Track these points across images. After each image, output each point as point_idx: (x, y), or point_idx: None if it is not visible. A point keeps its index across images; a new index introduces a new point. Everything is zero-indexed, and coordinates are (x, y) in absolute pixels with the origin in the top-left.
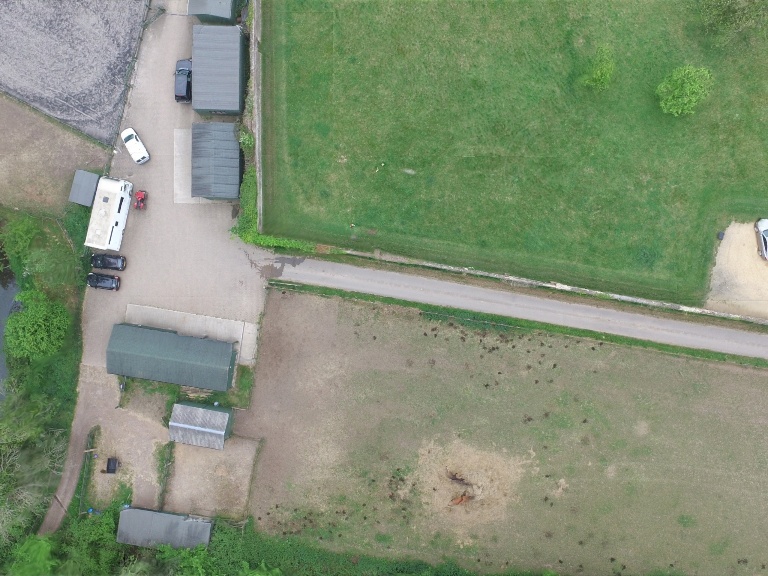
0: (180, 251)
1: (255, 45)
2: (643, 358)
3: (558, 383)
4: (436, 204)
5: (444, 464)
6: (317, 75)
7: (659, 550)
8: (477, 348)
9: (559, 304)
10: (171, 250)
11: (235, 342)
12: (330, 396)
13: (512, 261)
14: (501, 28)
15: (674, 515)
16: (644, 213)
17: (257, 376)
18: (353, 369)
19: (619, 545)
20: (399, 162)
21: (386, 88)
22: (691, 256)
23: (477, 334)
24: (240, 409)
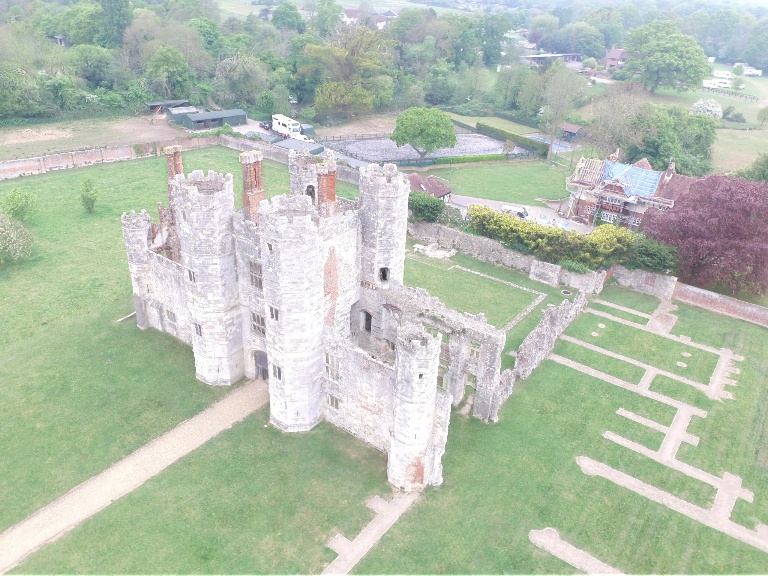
0: None
1: None
2: None
3: None
4: None
5: (55, 135)
6: None
7: None
8: None
9: None
10: None
11: None
12: None
13: (79, 171)
14: None
15: None
16: None
17: None
18: None
19: None
20: None
21: None
22: None
23: None
24: None
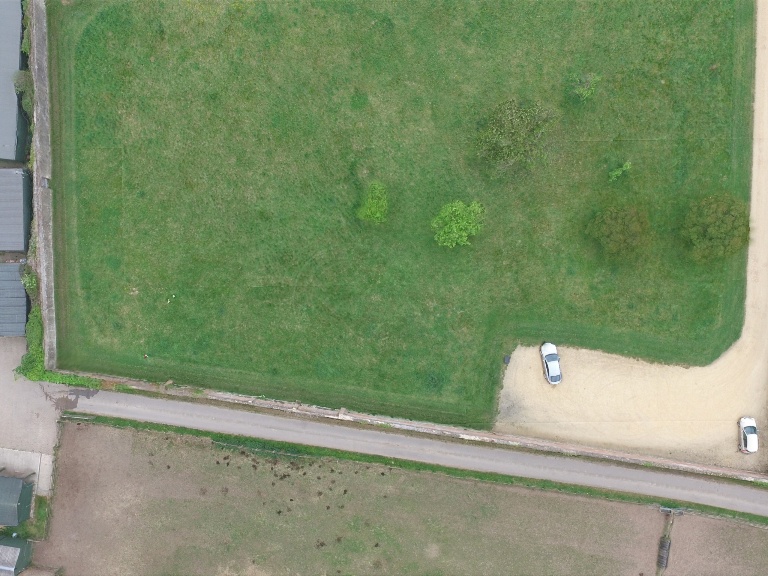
0: None
1: (39, 186)
2: (432, 482)
3: (349, 508)
4: (227, 334)
5: None
6: (107, 210)
7: None
8: (269, 476)
9: (349, 430)
10: None
11: (31, 474)
12: (127, 525)
13: (303, 388)
14: (286, 160)
15: None
16: (431, 339)
17: (55, 506)
18: (148, 498)
19: None
20: (189, 293)
21: (175, 221)
22: (479, 380)
23: (268, 462)
24: (35, 541)
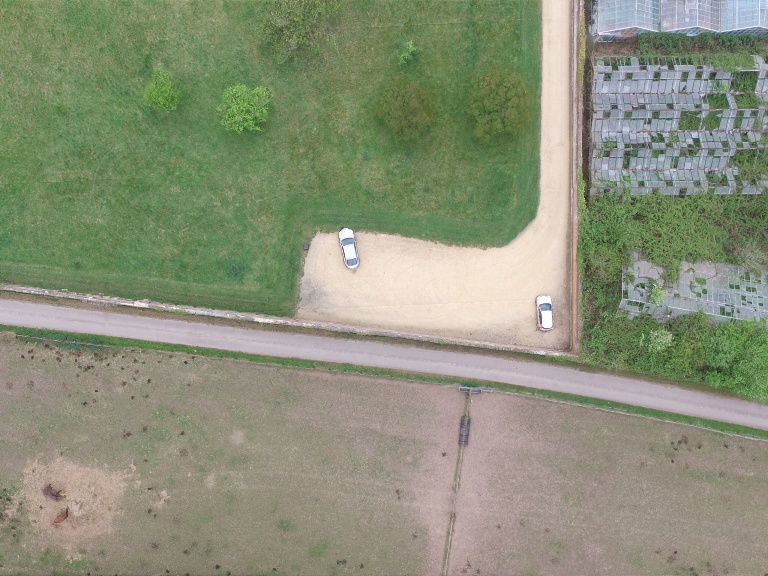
0: None
1: None
2: (235, 369)
3: (154, 398)
4: (29, 229)
5: (48, 482)
6: None
7: (261, 555)
8: (73, 368)
9: (151, 321)
10: None
11: None
12: None
13: (107, 281)
14: (82, 55)
15: (274, 520)
16: (231, 228)
17: None
18: None
19: (223, 552)
20: None
21: None
22: (279, 268)
23: (72, 354)
24: None
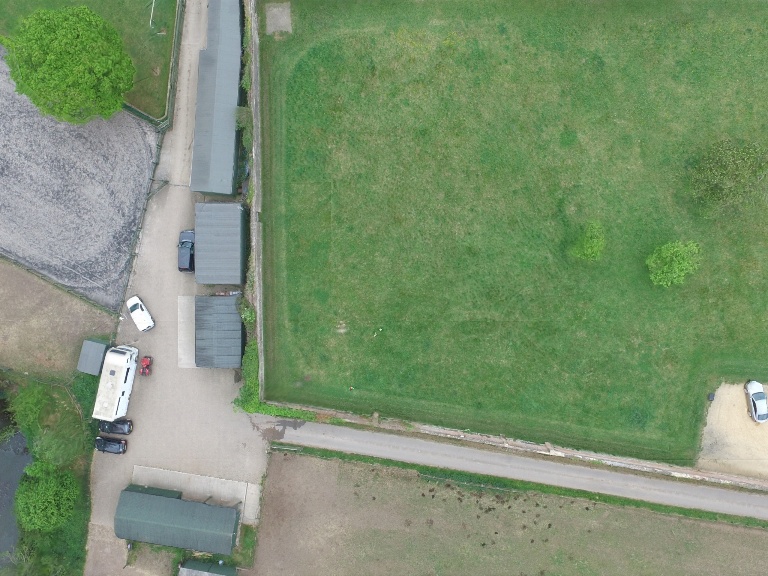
0: (185, 414)
1: (255, 220)
2: (636, 517)
3: (553, 542)
4: (433, 367)
5: None
6: (316, 244)
7: None
8: (474, 509)
9: (553, 465)
10: (176, 413)
11: (239, 503)
12: (331, 554)
13: (507, 422)
14: (494, 197)
15: None
16: (636, 375)
17: (260, 535)
18: (353, 528)
19: None
20: (396, 327)
21: (383, 256)
22: (682, 417)
23: (474, 495)
24: None
